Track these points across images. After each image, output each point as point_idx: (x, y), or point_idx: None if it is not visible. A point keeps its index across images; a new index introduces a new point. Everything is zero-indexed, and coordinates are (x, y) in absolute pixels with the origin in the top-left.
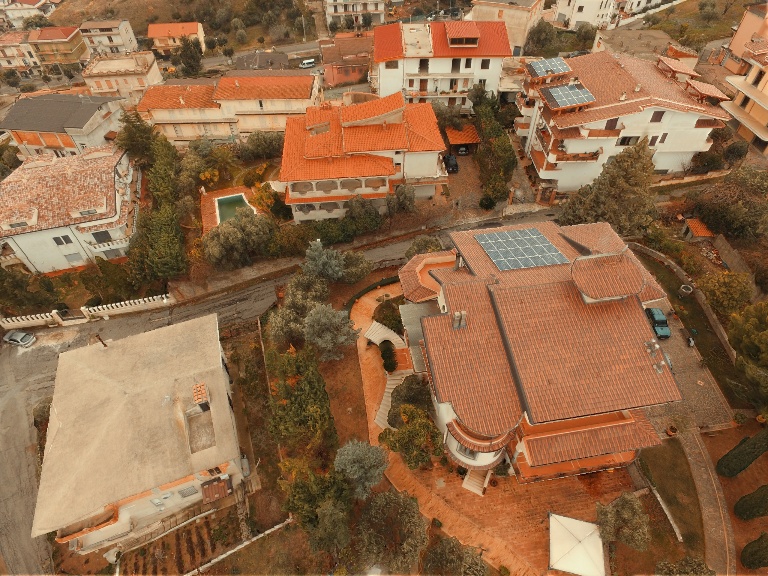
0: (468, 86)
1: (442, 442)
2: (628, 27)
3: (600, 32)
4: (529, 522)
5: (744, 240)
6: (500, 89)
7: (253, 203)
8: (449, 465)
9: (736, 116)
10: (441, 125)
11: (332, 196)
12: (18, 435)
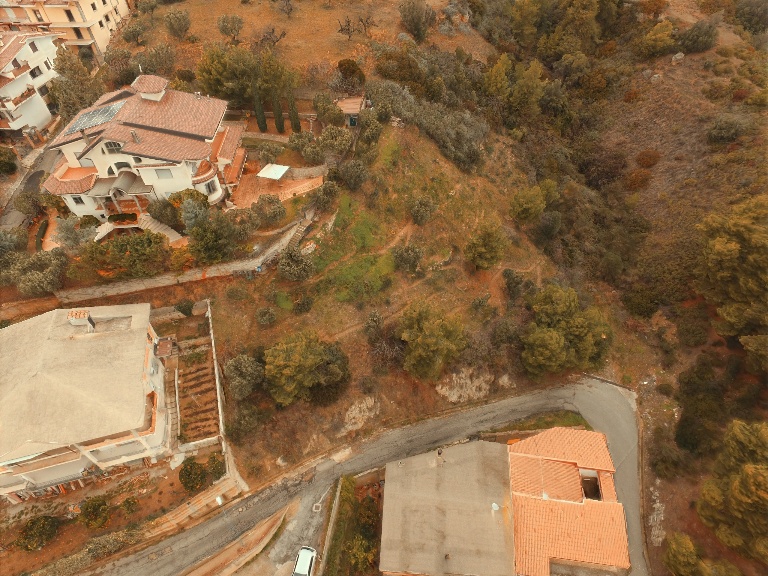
0: None
1: None
2: None
3: None
4: (257, 193)
5: None
6: None
7: None
8: None
9: None
10: None
11: None
12: None
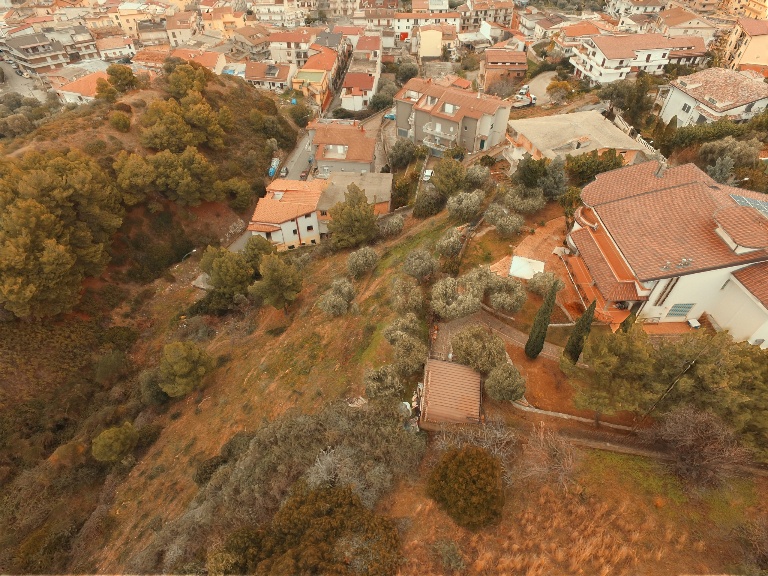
0: None
1: None
2: None
3: None
4: None
5: None
6: None
7: None
8: None
9: None
10: None
11: None
12: None
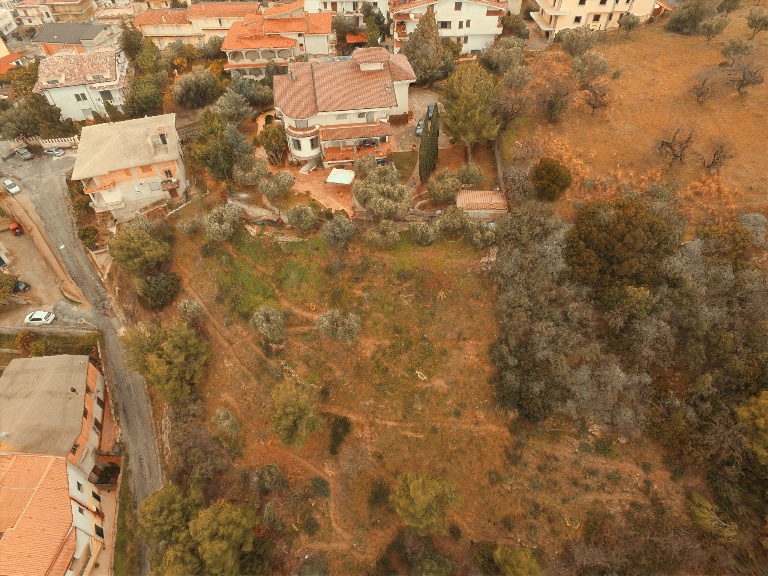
0: None
1: (287, 147)
2: None
3: None
4: None
5: (496, 73)
6: (388, 10)
7: None
8: (293, 164)
9: (535, 19)
10: (343, 32)
11: (257, 64)
12: (55, 193)
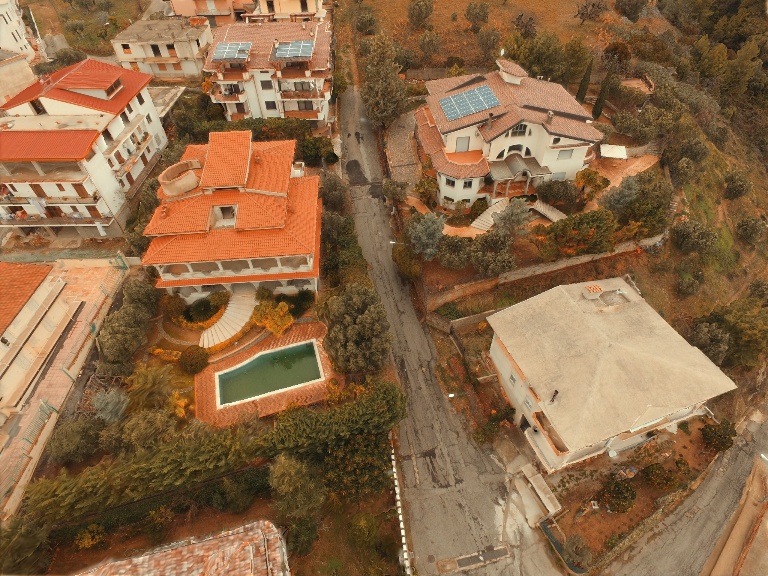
0: (141, 130)
1: None
2: (54, 46)
3: (117, 40)
4: None
5: None
6: (160, 116)
7: (281, 330)
8: None
9: None
10: None
11: None
12: None
